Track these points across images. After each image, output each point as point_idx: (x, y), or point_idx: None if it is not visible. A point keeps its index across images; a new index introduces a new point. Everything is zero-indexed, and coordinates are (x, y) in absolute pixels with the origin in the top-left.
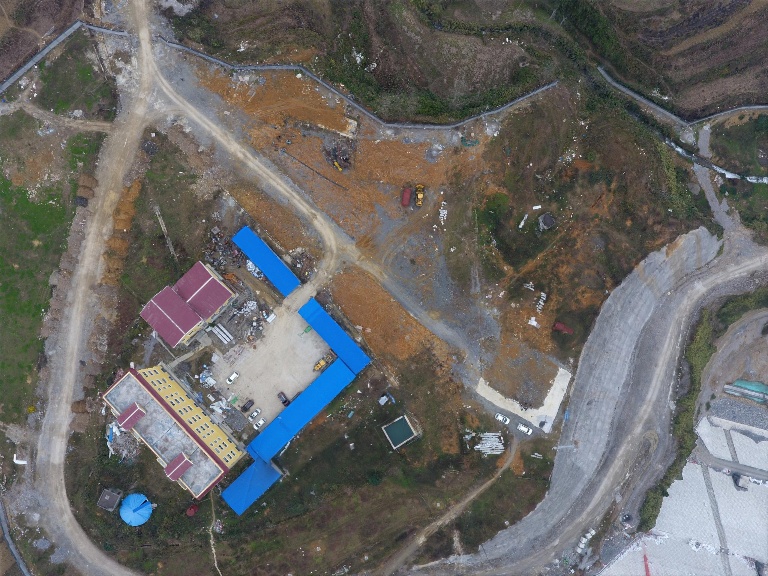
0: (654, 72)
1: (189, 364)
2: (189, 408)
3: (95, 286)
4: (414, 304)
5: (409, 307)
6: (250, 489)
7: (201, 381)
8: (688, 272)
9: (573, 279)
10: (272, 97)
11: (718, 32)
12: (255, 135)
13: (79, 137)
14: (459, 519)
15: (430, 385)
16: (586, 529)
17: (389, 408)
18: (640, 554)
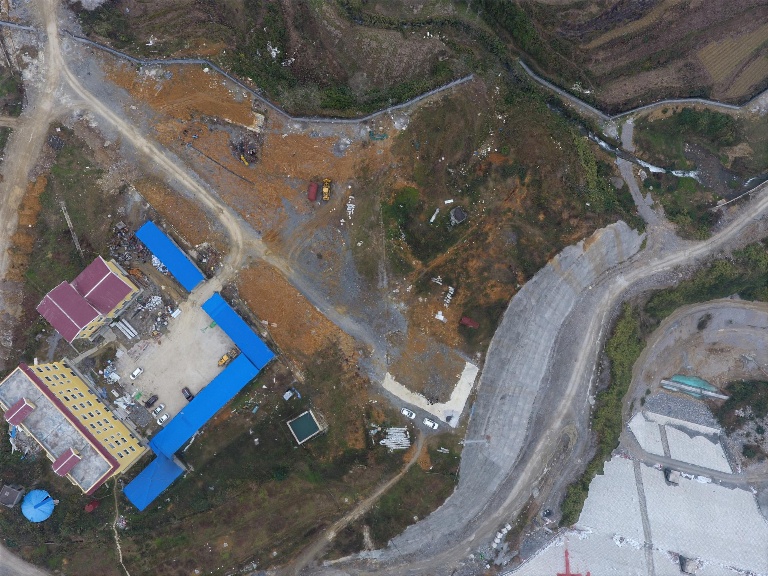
0: (575, 66)
1: (93, 360)
2: (88, 403)
3: None
4: (321, 299)
5: (315, 302)
6: (152, 485)
7: (105, 377)
8: (610, 266)
9: (482, 273)
10: (179, 91)
11: (638, 25)
12: (161, 129)
13: None
14: (368, 514)
15: (336, 380)
16: (502, 524)
17: (294, 403)
18: (562, 549)
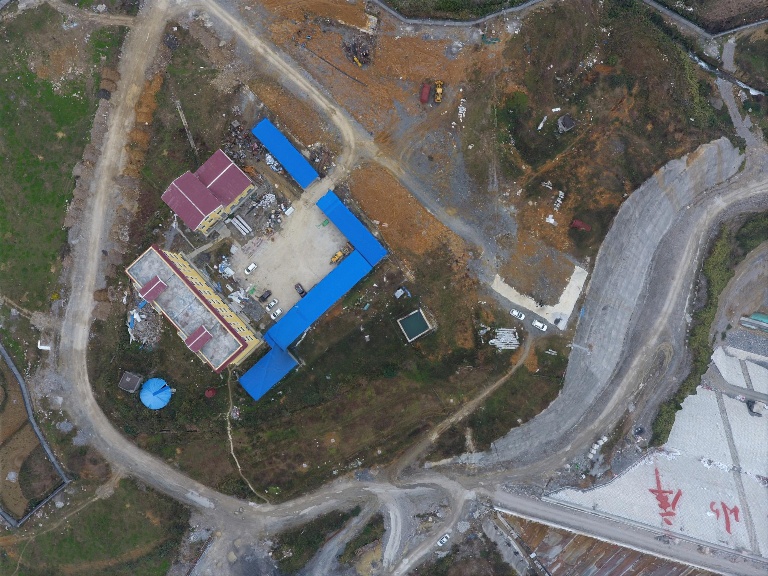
0: None
1: (208, 255)
2: (208, 292)
3: (117, 177)
4: (431, 200)
5: (426, 203)
6: (267, 375)
7: (220, 271)
8: (708, 187)
9: (592, 179)
10: None
11: None
12: (275, 30)
13: (102, 31)
14: (472, 416)
15: (446, 280)
16: (598, 436)
17: (405, 302)
18: (651, 468)
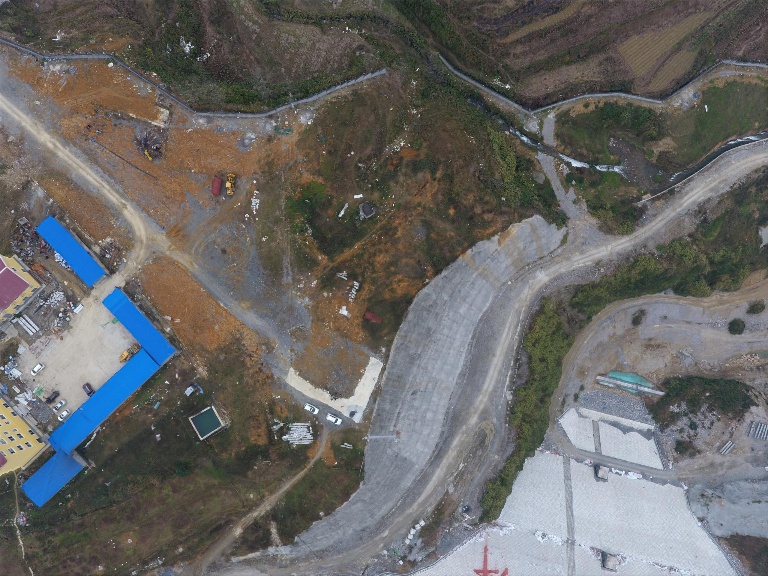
0: (493, 60)
1: None
2: None
3: None
4: (224, 294)
5: (219, 297)
6: (50, 481)
7: (6, 373)
8: (530, 261)
9: (388, 268)
10: (83, 86)
11: (556, 19)
12: (65, 125)
13: None
14: (274, 510)
15: (239, 375)
16: (417, 520)
17: (197, 399)
18: (481, 545)
